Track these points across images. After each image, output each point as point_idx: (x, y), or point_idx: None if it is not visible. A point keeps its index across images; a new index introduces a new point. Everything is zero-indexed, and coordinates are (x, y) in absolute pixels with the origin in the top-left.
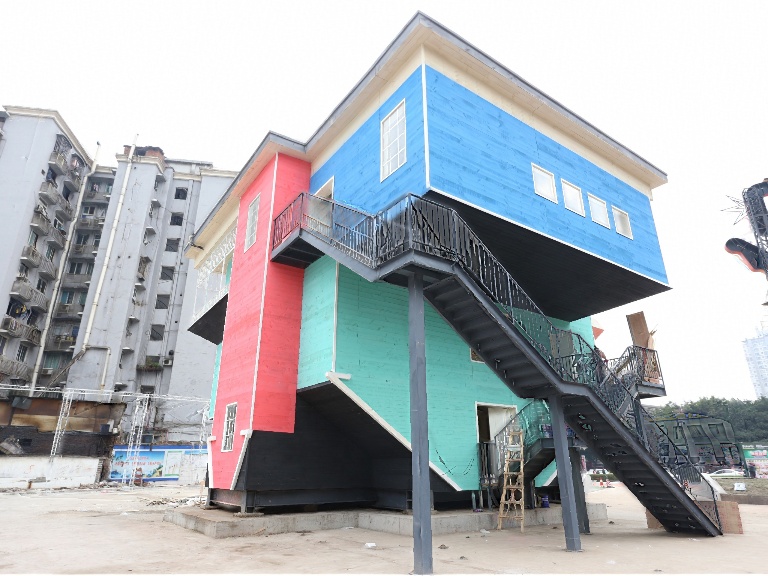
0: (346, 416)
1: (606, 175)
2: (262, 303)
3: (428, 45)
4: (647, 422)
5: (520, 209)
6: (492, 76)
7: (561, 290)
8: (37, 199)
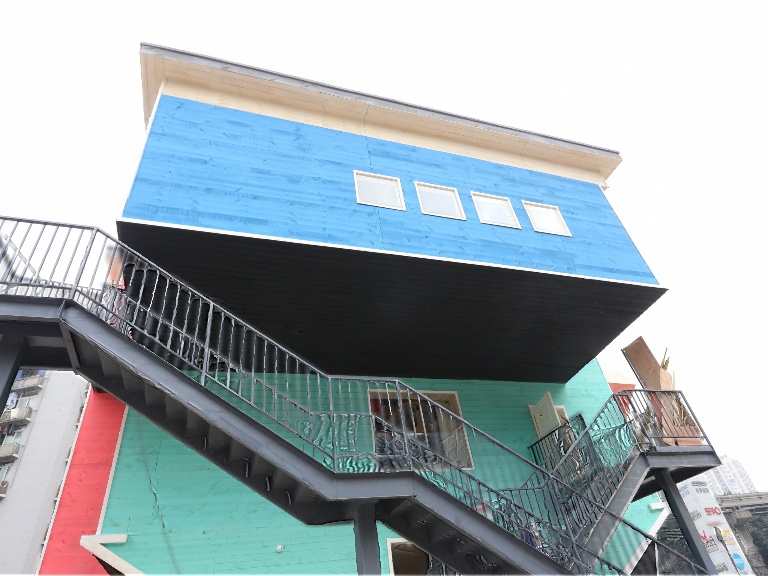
0: None
1: (510, 169)
2: None
3: (172, 77)
4: None
5: (322, 225)
6: (277, 90)
7: (495, 335)
8: (83, 398)
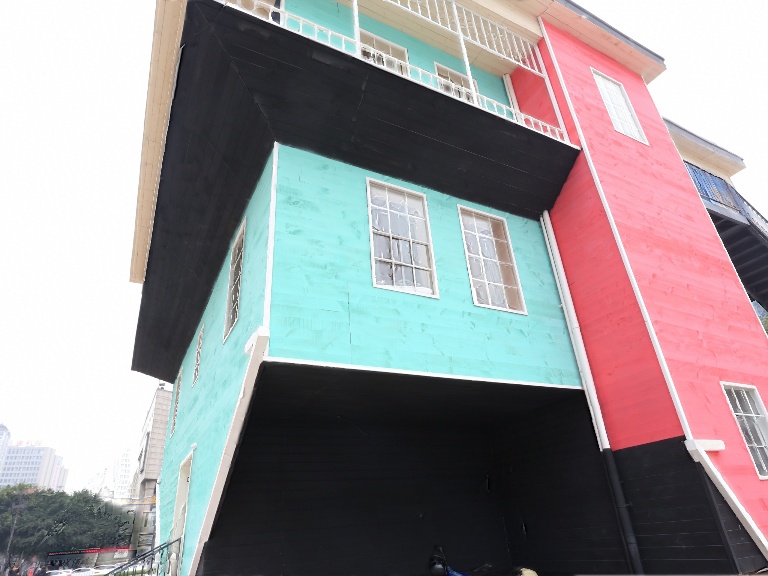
0: None
1: None
2: None
3: None
4: (120, 505)
5: None
6: None
7: None
8: None
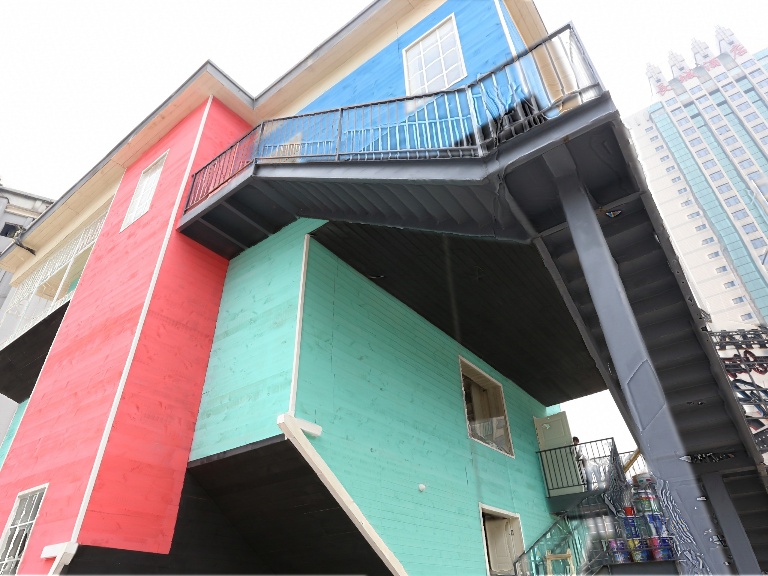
0: (286, 518)
1: None
2: (149, 291)
3: None
4: None
5: None
6: None
7: (571, 351)
8: None
